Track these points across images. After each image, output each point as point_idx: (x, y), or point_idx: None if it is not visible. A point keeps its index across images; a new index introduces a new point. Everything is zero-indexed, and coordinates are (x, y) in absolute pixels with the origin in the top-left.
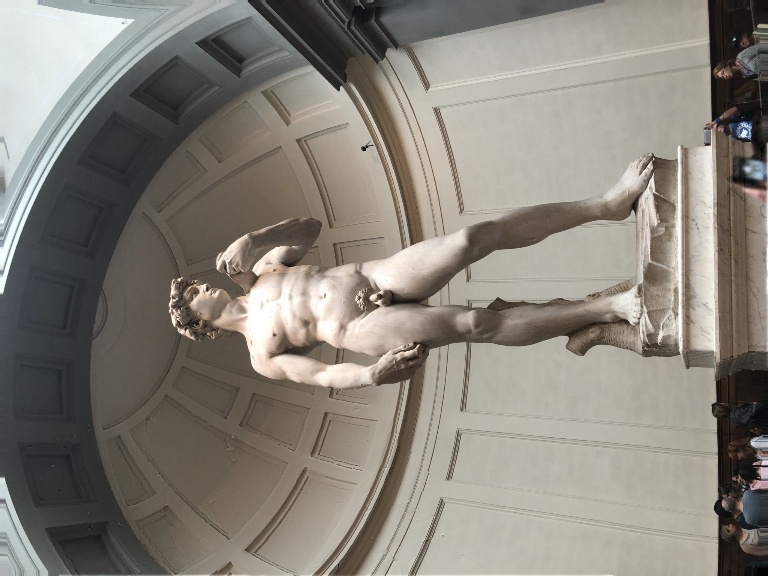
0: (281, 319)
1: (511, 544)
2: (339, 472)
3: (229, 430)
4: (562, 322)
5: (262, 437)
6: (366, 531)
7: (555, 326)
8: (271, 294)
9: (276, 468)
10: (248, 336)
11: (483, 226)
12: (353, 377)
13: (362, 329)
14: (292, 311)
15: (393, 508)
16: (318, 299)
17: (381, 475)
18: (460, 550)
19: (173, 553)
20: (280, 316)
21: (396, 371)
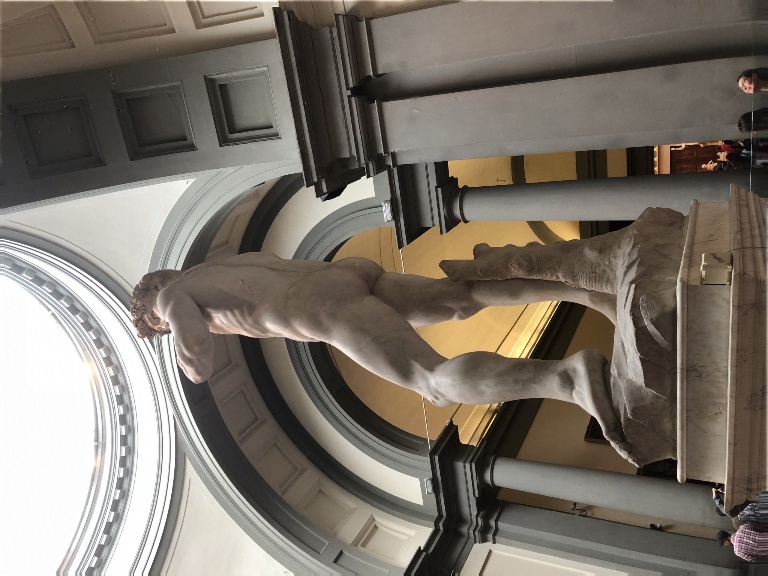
0: None
1: None
2: None
3: None
4: None
5: None
6: None
7: None
8: None
9: None
10: None
11: None
12: None
13: None
14: None
15: None
16: None
17: None
18: None
19: (141, 14)
20: None
21: None
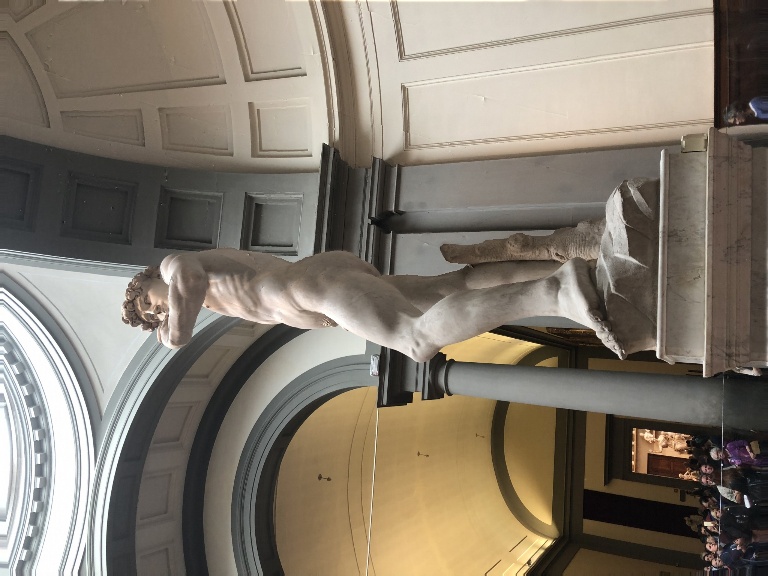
0: None
1: None
2: None
3: None
4: None
5: None
6: None
7: None
8: None
9: None
10: None
11: (432, 355)
12: None
13: None
14: None
15: None
16: None
17: None
18: None
19: (209, 137)
20: None
21: None
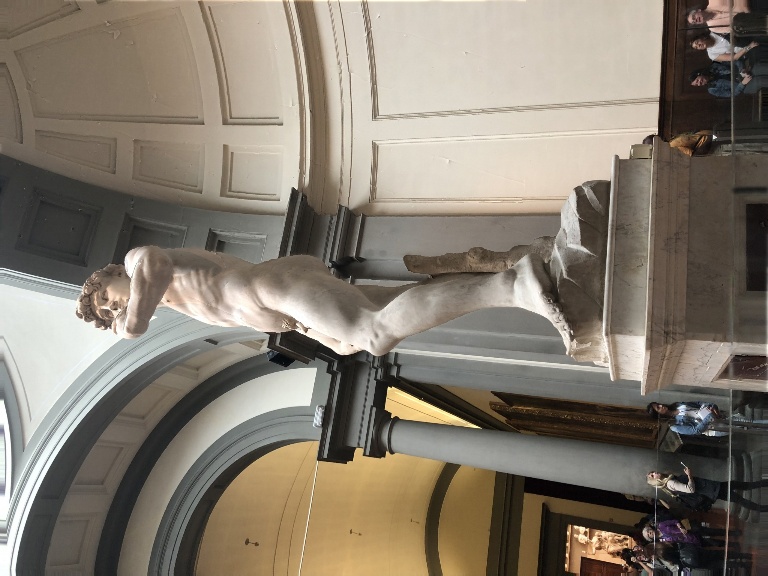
0: None
1: (449, 4)
2: None
3: (95, 18)
4: None
5: (132, 2)
6: (309, 55)
7: None
8: None
9: (173, 19)
10: None
11: (390, 347)
12: None
13: None
14: None
15: (316, 11)
16: None
17: None
18: (403, 31)
19: (181, 173)
20: None
21: None
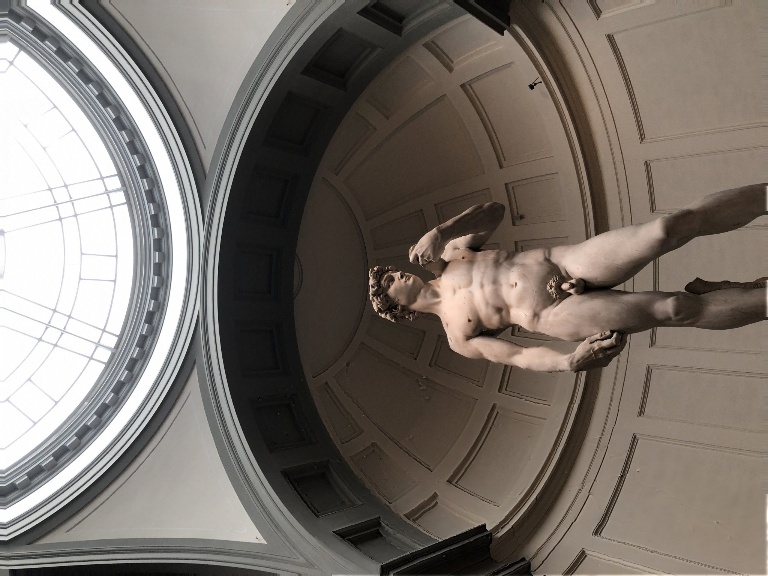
0: (475, 306)
1: (712, 482)
2: (528, 408)
3: (420, 370)
4: None
5: (451, 376)
6: (560, 466)
7: (765, 311)
8: (463, 282)
9: (467, 404)
10: (443, 318)
11: (681, 217)
12: (550, 363)
13: (556, 317)
14: (485, 299)
15: (585, 444)
16: (509, 288)
17: (570, 412)
18: (657, 486)
19: (385, 484)
20: (473, 303)
21: (594, 360)
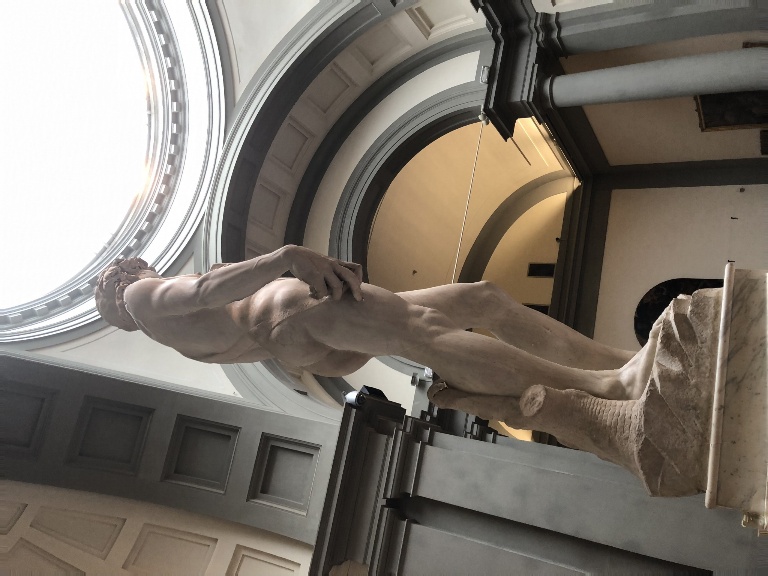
0: None
1: None
2: None
3: None
4: (539, 361)
5: None
6: None
7: (528, 358)
8: None
9: None
10: None
11: None
12: None
13: None
14: None
15: None
16: None
17: None
18: None
19: None
20: None
21: (320, 256)
